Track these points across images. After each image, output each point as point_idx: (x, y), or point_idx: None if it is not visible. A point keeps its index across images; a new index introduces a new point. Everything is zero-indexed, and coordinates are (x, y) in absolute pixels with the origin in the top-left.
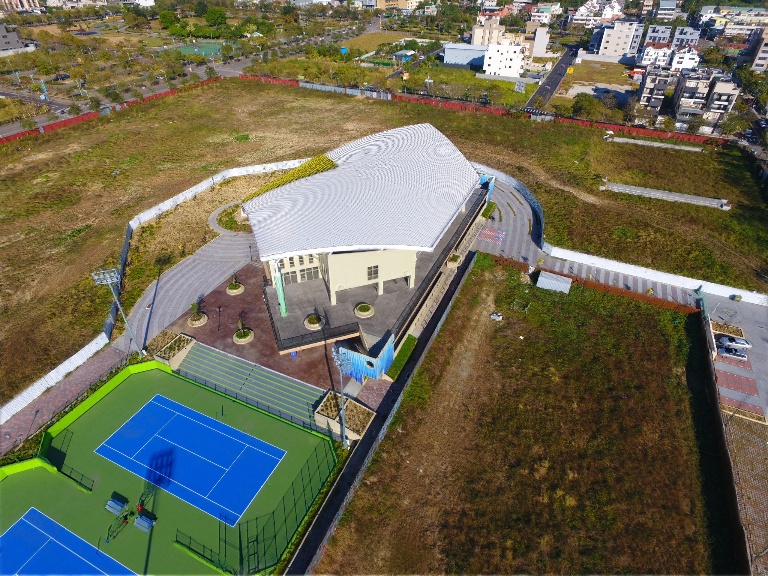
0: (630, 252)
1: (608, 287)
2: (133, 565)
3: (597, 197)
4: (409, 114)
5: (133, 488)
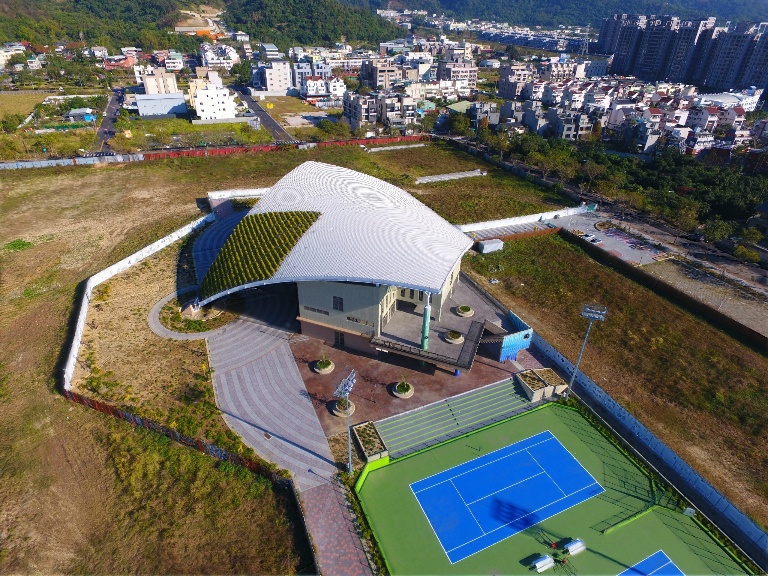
0: (487, 214)
1: (517, 235)
2: (613, 572)
3: (421, 189)
4: (187, 168)
5: (525, 545)
